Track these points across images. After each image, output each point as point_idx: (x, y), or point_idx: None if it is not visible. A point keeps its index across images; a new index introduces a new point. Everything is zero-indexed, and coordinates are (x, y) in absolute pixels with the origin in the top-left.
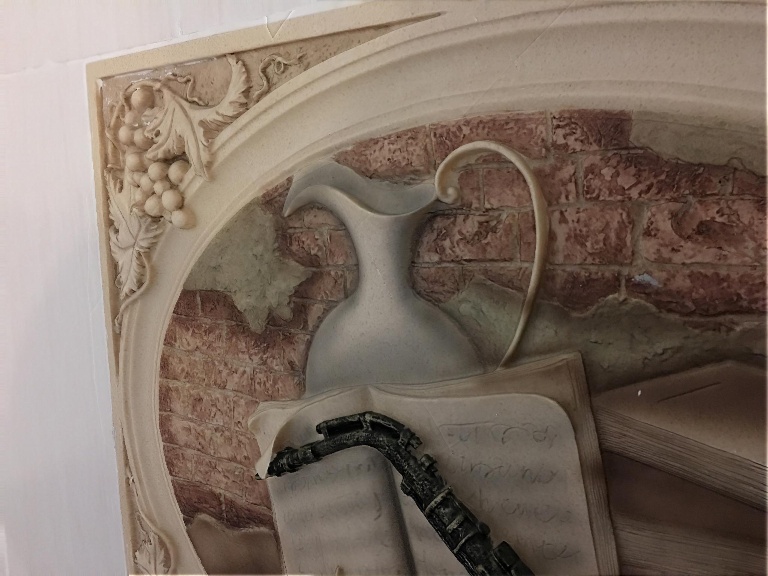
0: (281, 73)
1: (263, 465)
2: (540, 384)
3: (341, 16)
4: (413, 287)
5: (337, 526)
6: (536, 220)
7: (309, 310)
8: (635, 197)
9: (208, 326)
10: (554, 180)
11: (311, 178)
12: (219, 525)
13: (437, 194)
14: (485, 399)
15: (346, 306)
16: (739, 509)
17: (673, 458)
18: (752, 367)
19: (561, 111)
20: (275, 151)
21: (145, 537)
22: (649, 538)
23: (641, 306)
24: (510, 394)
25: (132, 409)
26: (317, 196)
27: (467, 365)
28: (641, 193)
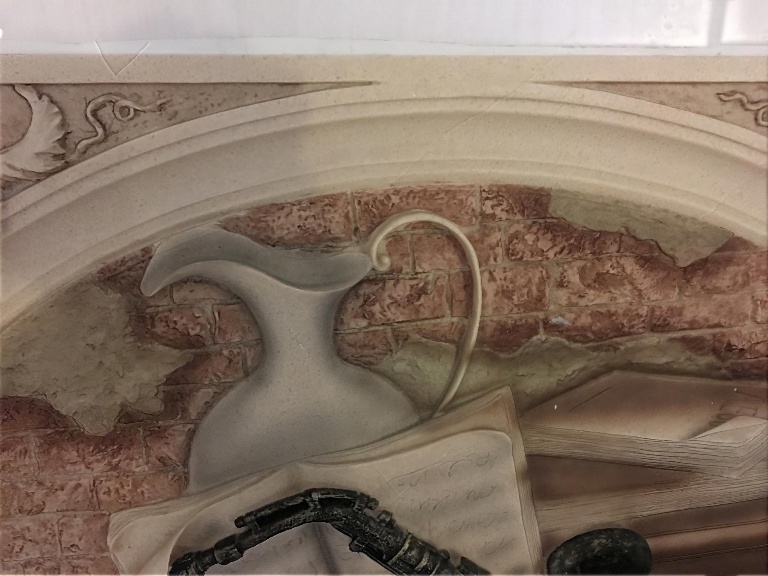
0: (128, 120)
1: None
2: (480, 419)
3: (235, 65)
4: (338, 354)
5: None
6: (479, 284)
7: (191, 397)
8: (552, 257)
9: None
10: (483, 245)
11: (185, 248)
12: None
13: (374, 265)
14: (436, 445)
15: (252, 386)
16: (621, 469)
17: (579, 448)
18: (630, 372)
19: (490, 185)
20: (114, 215)
21: None
22: (562, 509)
23: (559, 342)
24: (458, 435)
25: None
26: (207, 272)
27: (405, 417)
28: (556, 254)
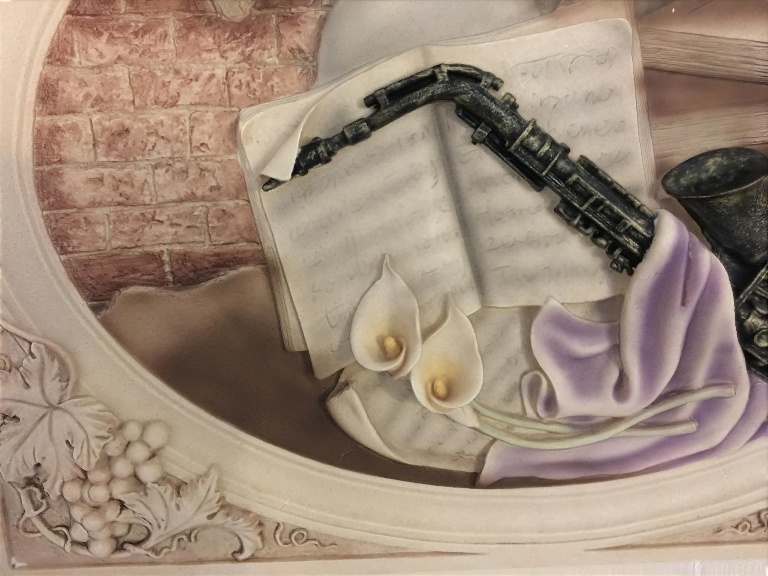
0: None
1: (284, 165)
2: (601, 13)
3: None
4: None
5: (383, 210)
6: None
7: None
8: None
9: (142, 24)
10: None
11: None
12: (164, 291)
13: None
14: (559, 31)
15: None
16: (736, 86)
17: (695, 59)
18: None
19: None
20: None
21: (2, 363)
22: (677, 128)
23: None
24: None
25: None
26: None
27: (528, 10)
28: None
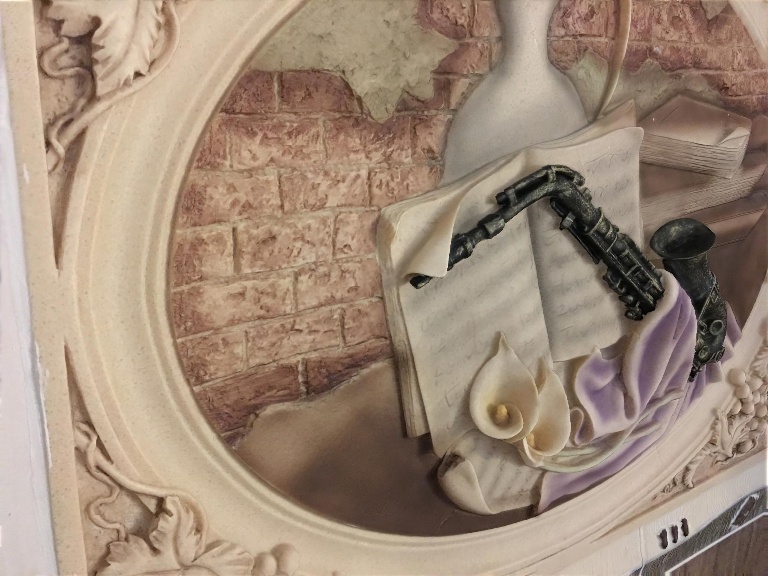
0: None
1: (440, 262)
2: (623, 122)
3: None
4: (548, 57)
5: (499, 293)
6: None
7: (454, 86)
8: None
9: (297, 124)
10: None
11: None
12: (301, 404)
13: None
14: None
15: (498, 77)
16: (680, 174)
17: (663, 154)
18: (685, 97)
19: None
20: None
21: (115, 534)
22: None
23: None
24: (617, 130)
25: (94, 310)
26: None
27: None
28: None
